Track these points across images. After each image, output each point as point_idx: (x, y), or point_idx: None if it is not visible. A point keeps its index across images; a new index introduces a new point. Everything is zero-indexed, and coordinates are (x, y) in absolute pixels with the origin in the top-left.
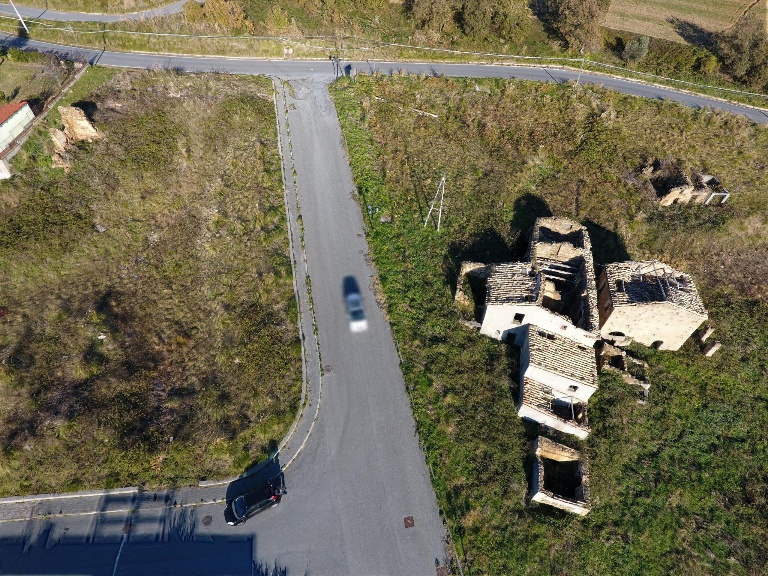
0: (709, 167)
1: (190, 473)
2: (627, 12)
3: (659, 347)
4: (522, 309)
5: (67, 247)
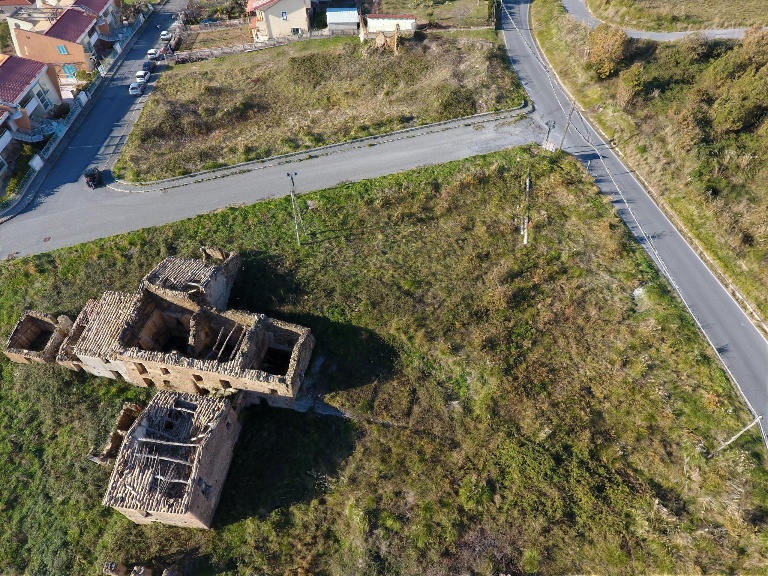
0: None
1: (125, 156)
2: None
3: None
4: None
5: (297, 80)
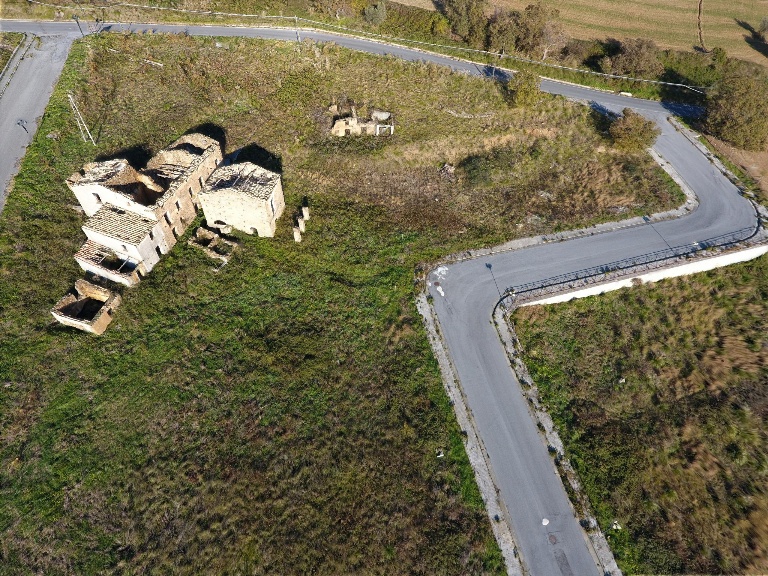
0: (395, 107)
1: None
2: None
3: (258, 234)
4: (92, 188)
5: None
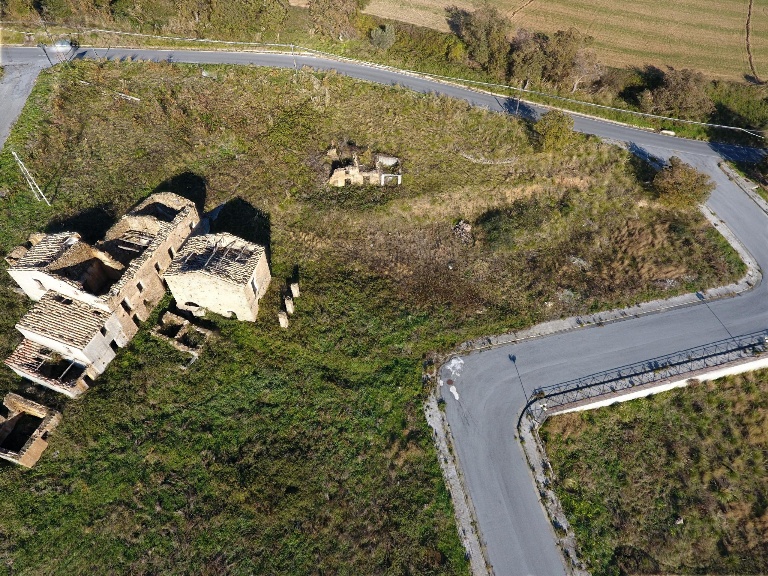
0: (404, 150)
1: None
2: (410, 1)
3: (237, 318)
4: (31, 274)
5: None
